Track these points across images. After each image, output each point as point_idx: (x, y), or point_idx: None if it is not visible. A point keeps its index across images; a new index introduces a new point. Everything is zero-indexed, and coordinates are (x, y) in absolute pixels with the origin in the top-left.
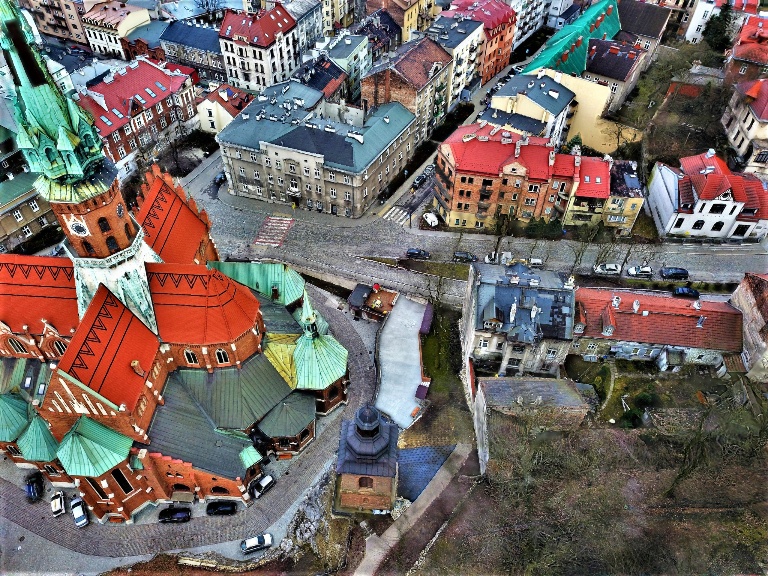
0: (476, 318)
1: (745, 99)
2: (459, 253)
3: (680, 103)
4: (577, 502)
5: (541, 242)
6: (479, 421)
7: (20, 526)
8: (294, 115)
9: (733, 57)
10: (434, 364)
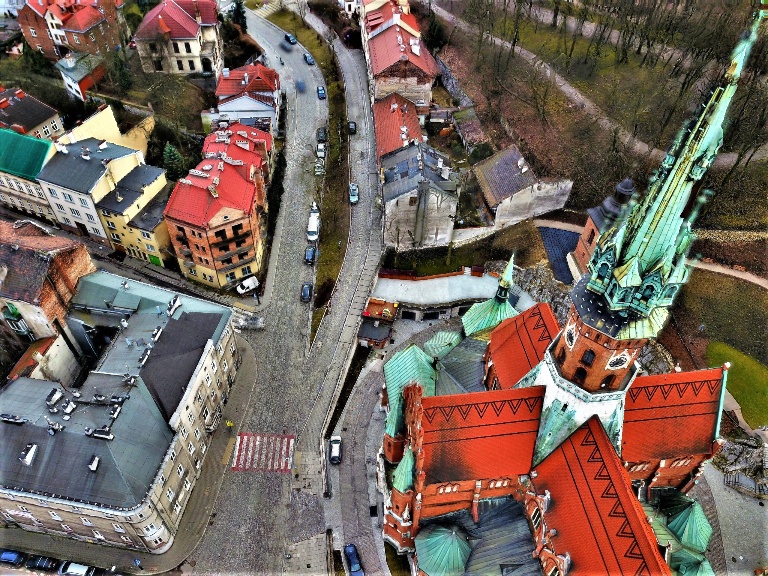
0: (451, 196)
1: (164, 37)
2: (308, 256)
3: (114, 86)
4: (566, 163)
5: (283, 205)
6: (526, 206)
7: (727, 569)
8: (100, 392)
9: (82, 32)
10: (446, 266)
